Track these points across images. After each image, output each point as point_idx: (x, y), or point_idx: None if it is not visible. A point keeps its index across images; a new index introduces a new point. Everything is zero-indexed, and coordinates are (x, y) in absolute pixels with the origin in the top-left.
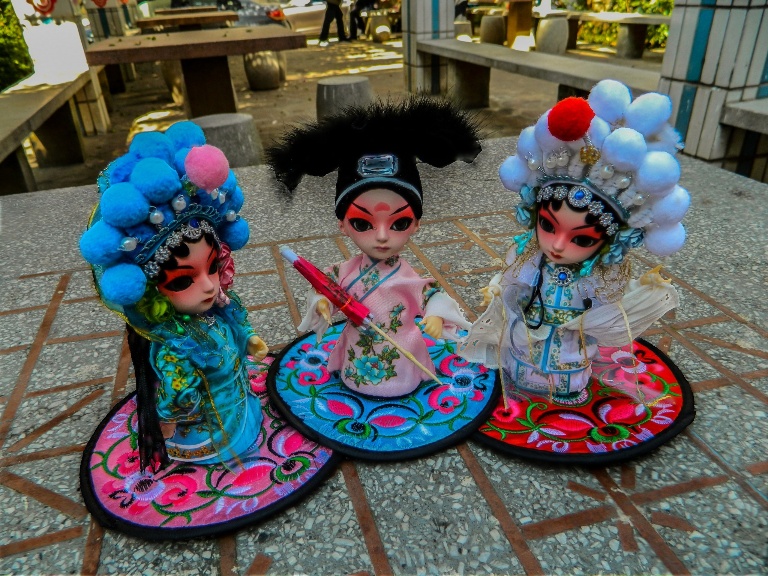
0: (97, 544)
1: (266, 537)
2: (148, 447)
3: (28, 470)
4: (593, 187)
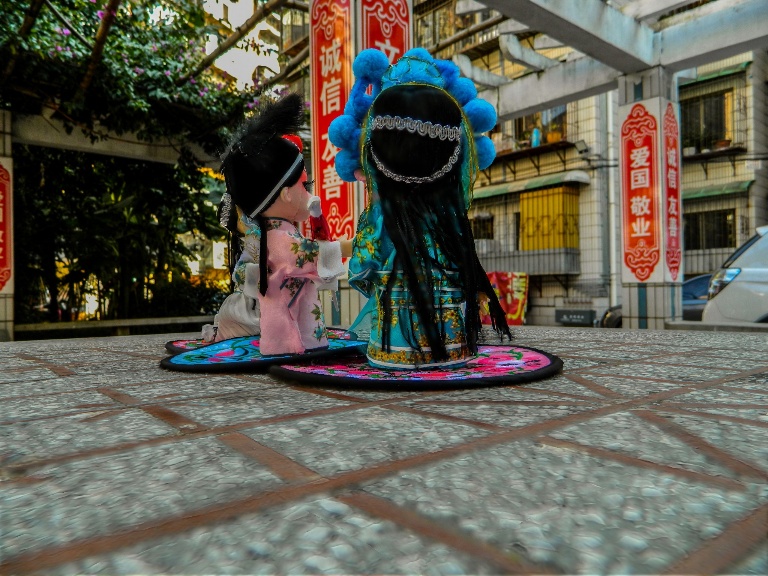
0: None
1: None
2: None
3: (585, 392)
4: None
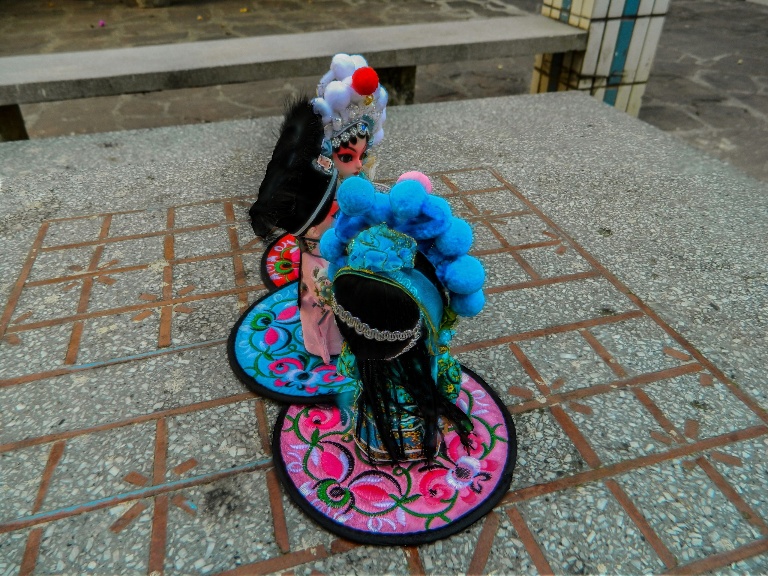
0: (521, 492)
1: (495, 392)
2: (464, 433)
3: None
4: (365, 119)
